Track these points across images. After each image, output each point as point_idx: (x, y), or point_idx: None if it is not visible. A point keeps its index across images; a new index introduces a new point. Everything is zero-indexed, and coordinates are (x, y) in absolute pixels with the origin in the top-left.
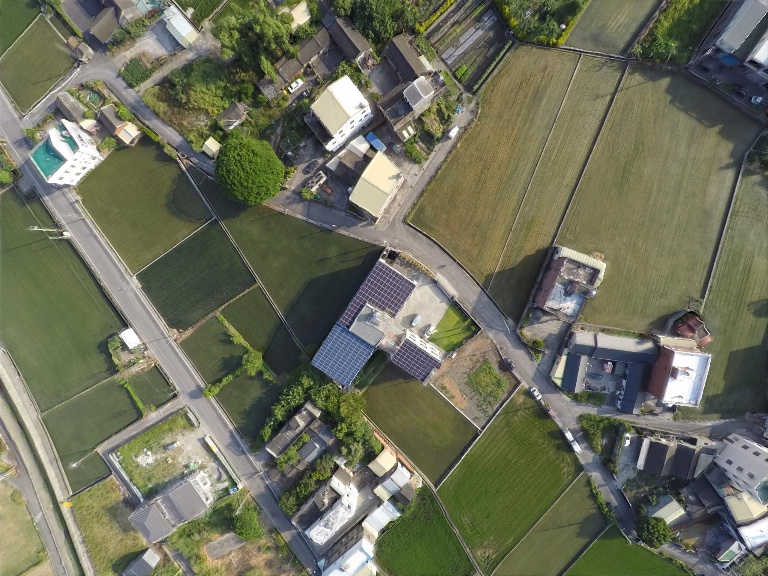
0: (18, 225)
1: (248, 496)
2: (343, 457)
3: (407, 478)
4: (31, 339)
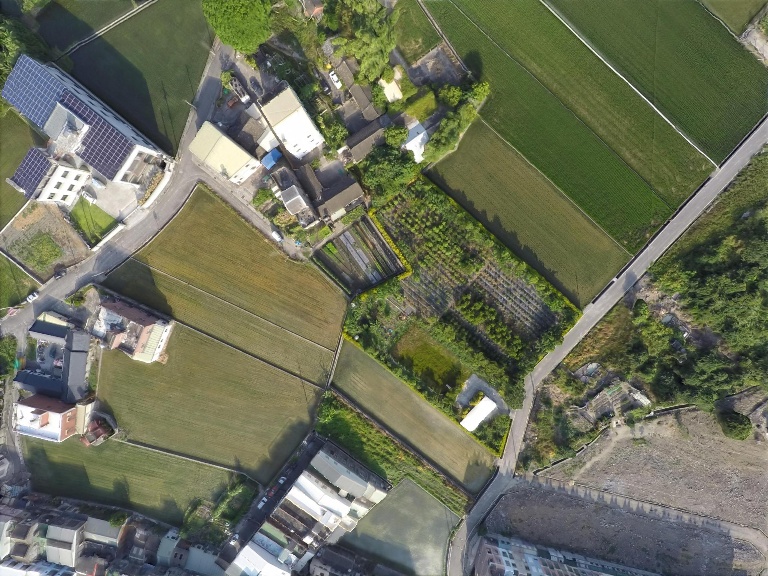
0: None
1: None
2: None
3: None
4: None
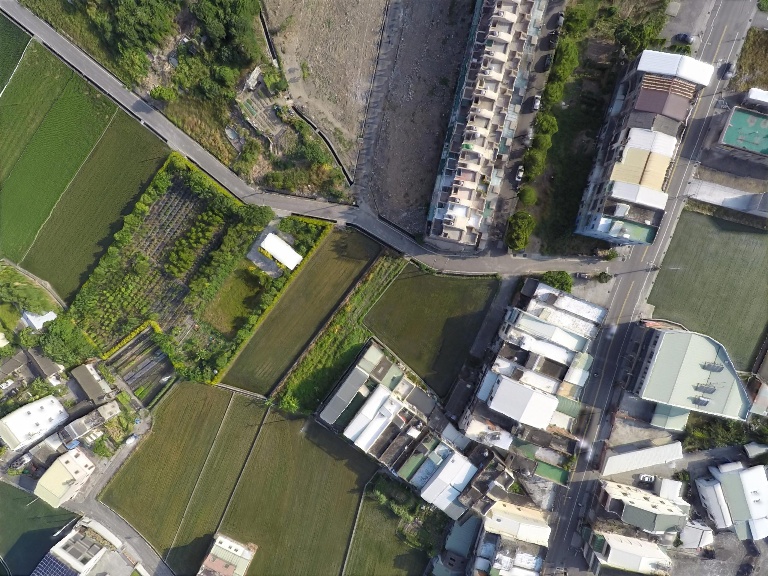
0: None
1: None
2: None
3: None
4: None
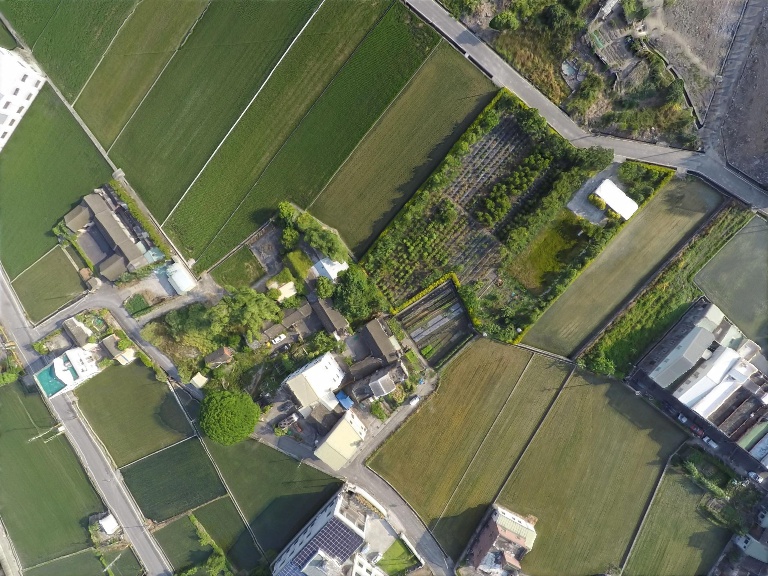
0: (19, 411)
1: None
2: None
3: None
4: (20, 507)
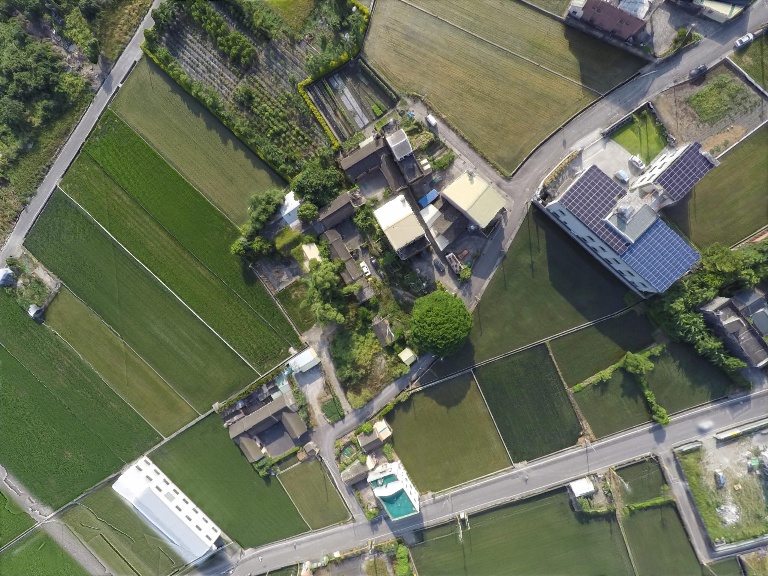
0: (444, 558)
1: None
2: None
3: None
4: None
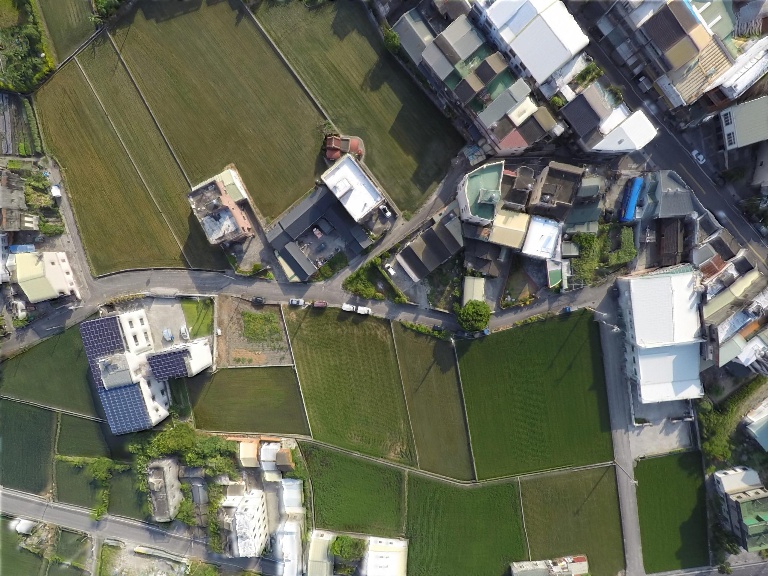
0: None
1: (200, 565)
2: (222, 477)
3: (273, 450)
4: None
